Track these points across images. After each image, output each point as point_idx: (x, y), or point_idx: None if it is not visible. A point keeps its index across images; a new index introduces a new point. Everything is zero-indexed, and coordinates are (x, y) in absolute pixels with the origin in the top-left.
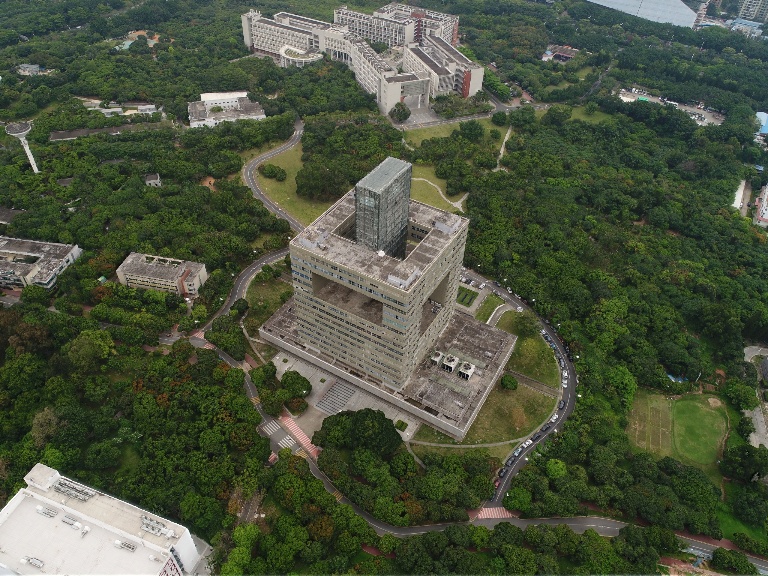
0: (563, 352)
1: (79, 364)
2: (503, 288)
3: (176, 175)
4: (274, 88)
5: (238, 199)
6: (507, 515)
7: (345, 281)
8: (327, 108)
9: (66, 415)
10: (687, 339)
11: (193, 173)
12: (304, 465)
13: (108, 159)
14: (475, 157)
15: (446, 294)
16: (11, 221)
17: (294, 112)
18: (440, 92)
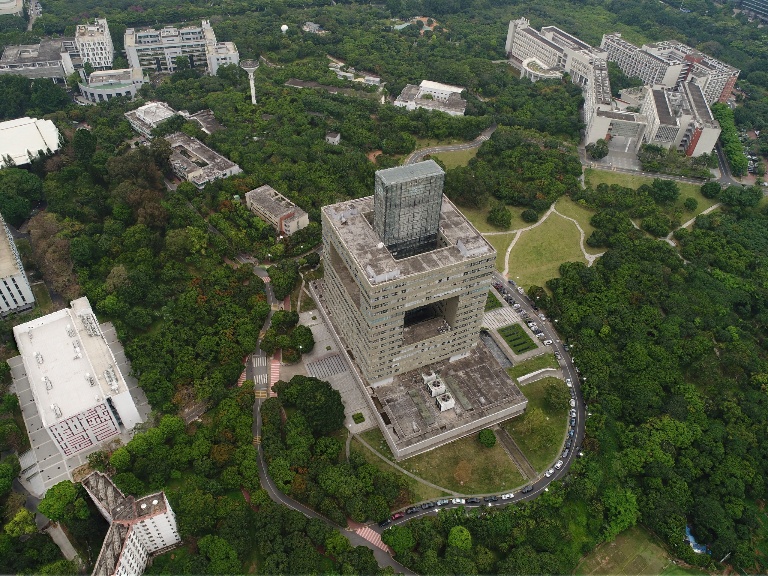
0: (578, 444)
1: (170, 248)
2: (569, 354)
3: (352, 139)
4: (493, 93)
5: None
6: (384, 547)
7: (344, 258)
8: (525, 123)
9: (132, 277)
10: (745, 511)
11: (365, 142)
12: (249, 399)
13: (313, 111)
14: (646, 218)
15: (455, 318)
16: (212, 133)
17: (492, 118)
18: (657, 142)
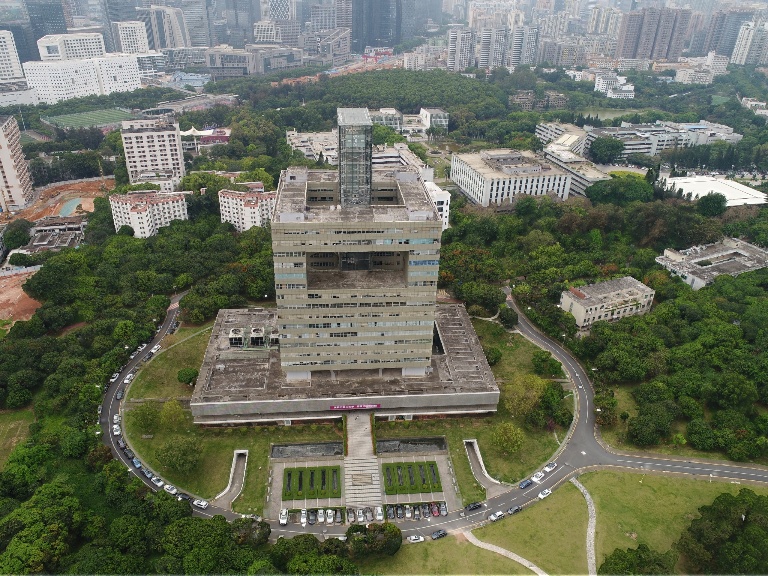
0: None
1: None
2: None
3: None
4: None
5: (760, 432)
6: None
7: None
8: None
9: (483, 219)
10: None
11: None
12: None
13: None
14: None
15: None
16: None
17: None
18: None
